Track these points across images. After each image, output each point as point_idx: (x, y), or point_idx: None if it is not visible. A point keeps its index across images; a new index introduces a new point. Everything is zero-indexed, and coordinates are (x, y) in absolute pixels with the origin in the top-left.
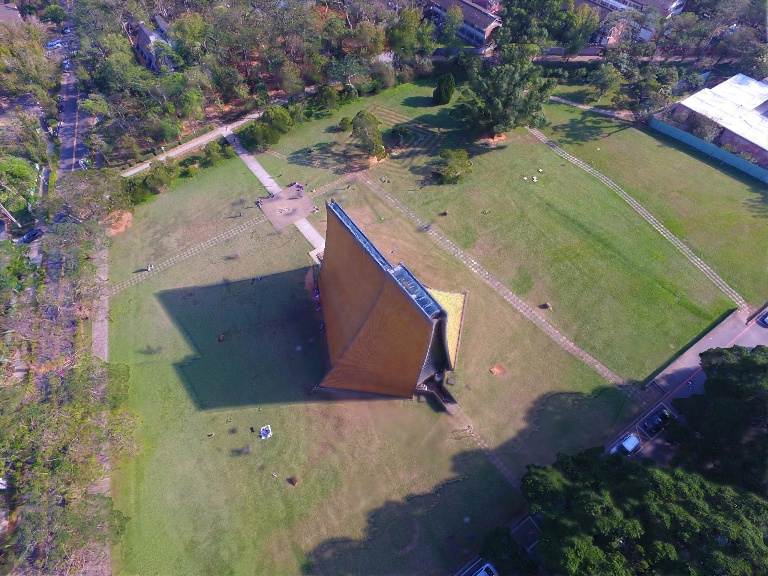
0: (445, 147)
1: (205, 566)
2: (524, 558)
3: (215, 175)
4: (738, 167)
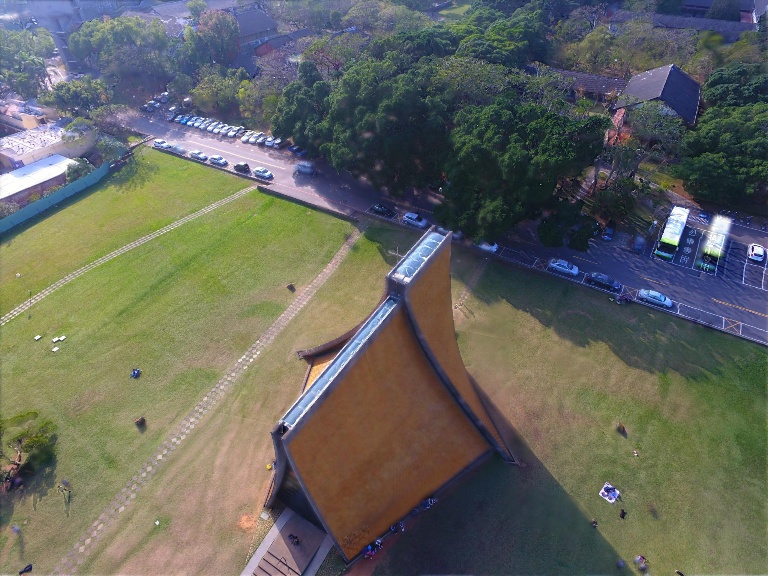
0: None
1: (765, 467)
2: None
3: None
4: (66, 196)
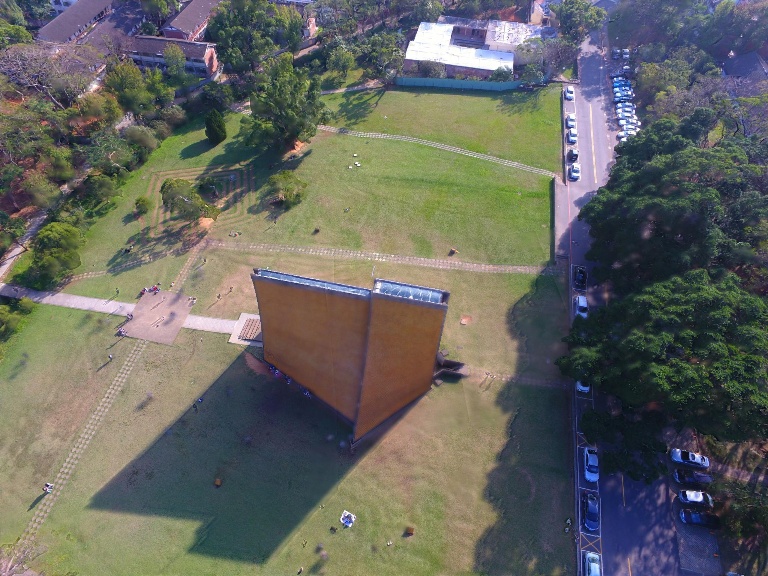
0: (261, 176)
1: None
2: (613, 419)
3: (30, 339)
4: (474, 88)
